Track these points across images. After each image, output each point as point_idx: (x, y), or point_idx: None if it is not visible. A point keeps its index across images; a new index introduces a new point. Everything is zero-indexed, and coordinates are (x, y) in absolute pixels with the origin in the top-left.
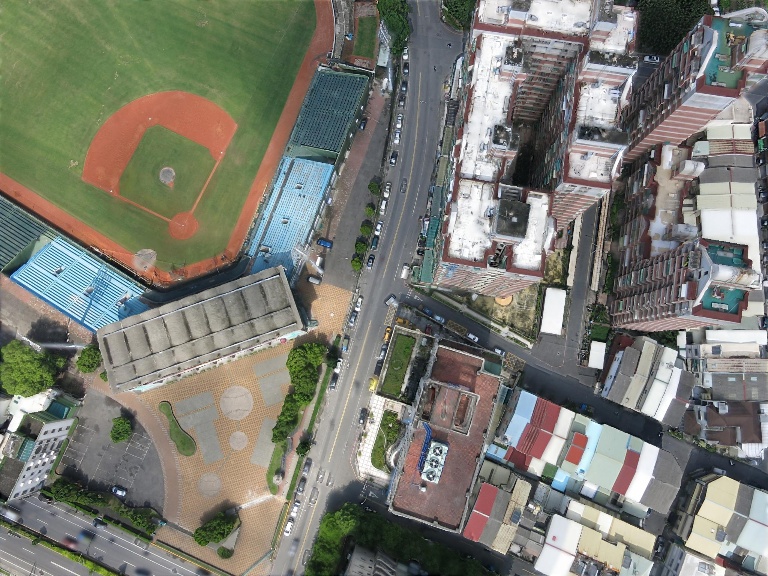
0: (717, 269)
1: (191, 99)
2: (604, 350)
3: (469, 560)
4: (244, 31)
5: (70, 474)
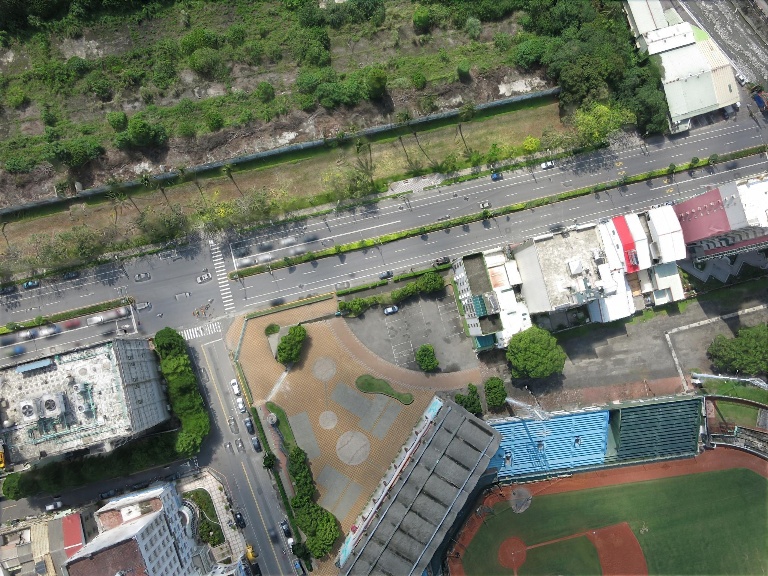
0: None
1: None
2: None
3: None
4: None
5: (439, 292)
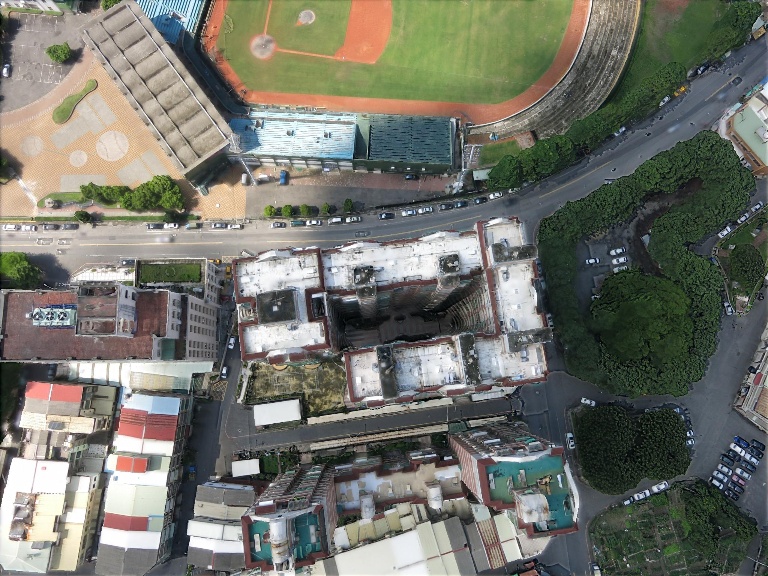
0: (277, 521)
1: (387, 14)
2: (253, 473)
3: (11, 396)
4: (469, 40)
5: (12, 24)
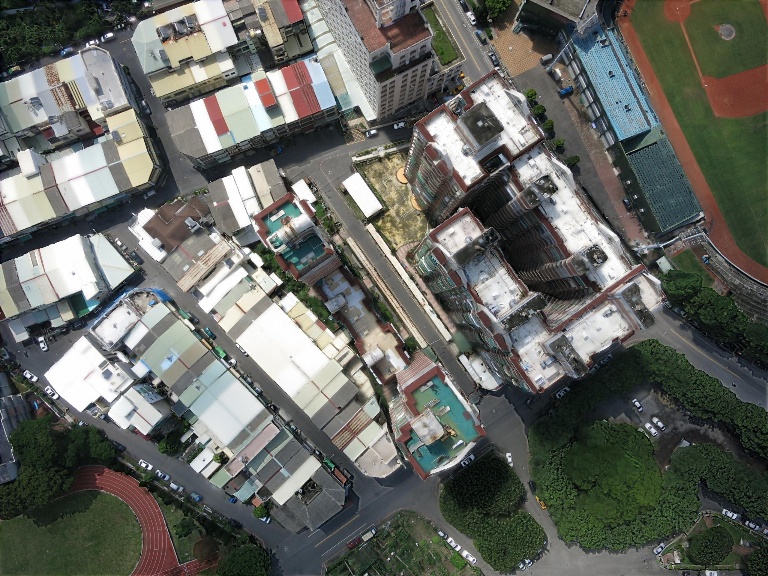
0: None
1: None
2: None
3: None
4: None
5: None
